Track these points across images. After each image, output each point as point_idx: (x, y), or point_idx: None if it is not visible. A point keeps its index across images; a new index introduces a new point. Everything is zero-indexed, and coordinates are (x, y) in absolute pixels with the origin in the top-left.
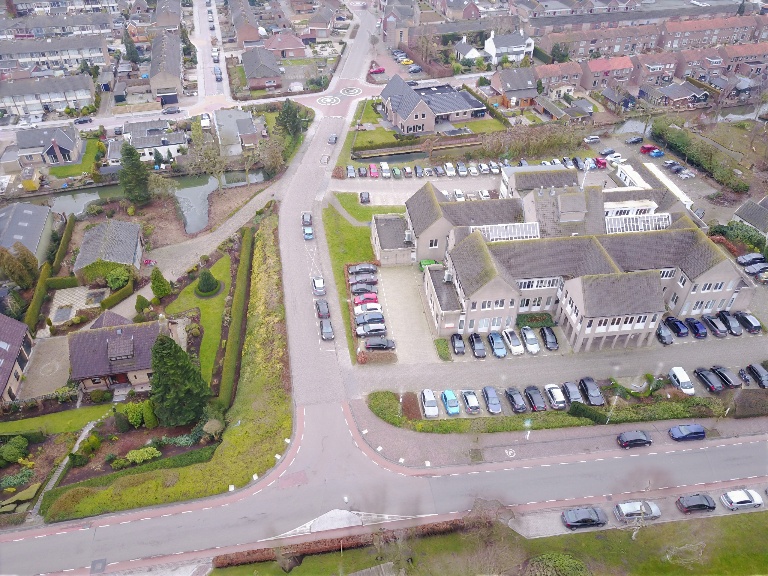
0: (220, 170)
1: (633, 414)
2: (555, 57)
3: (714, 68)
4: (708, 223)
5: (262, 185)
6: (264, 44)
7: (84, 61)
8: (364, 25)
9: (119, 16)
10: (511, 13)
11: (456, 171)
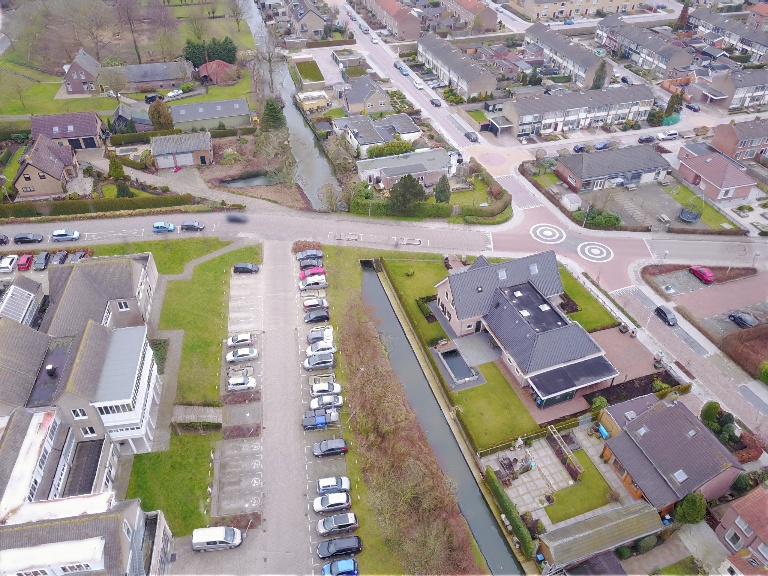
0: None
1: None
2: None
3: None
4: None
5: (299, 205)
6: None
7: (534, 68)
8: None
9: None
10: None
11: None
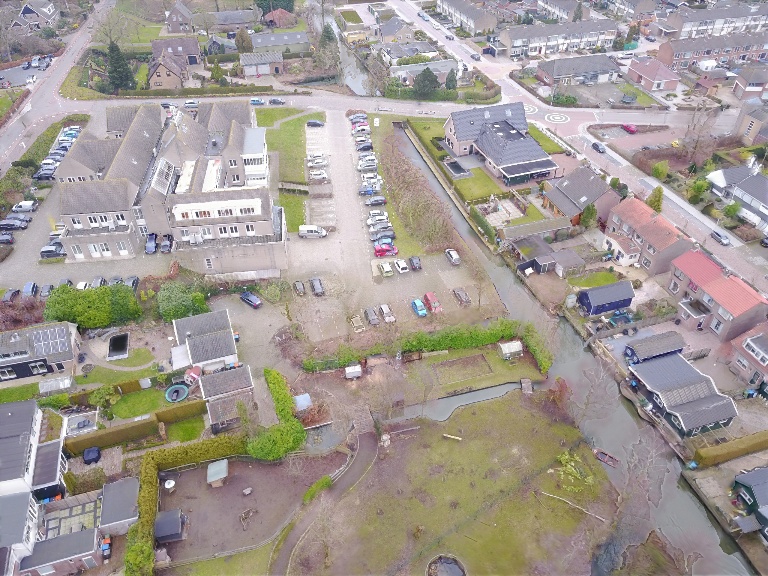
0: None
1: (8, 174)
2: None
3: None
4: None
5: None
6: None
7: (527, 11)
8: None
9: None
10: None
11: None
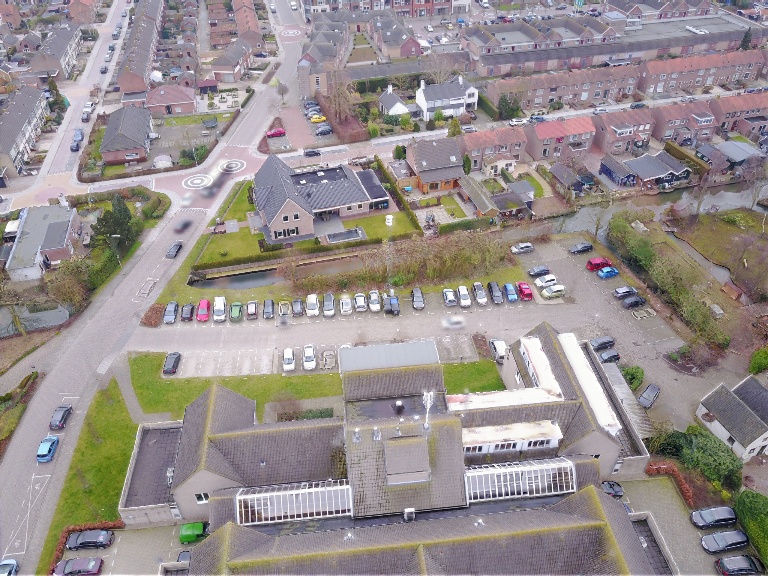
0: (8, 302)
1: None
2: (502, 111)
3: (703, 128)
4: (657, 426)
5: (46, 334)
6: (146, 97)
7: None
8: (287, 63)
9: (3, 55)
10: (461, 48)
11: (322, 306)
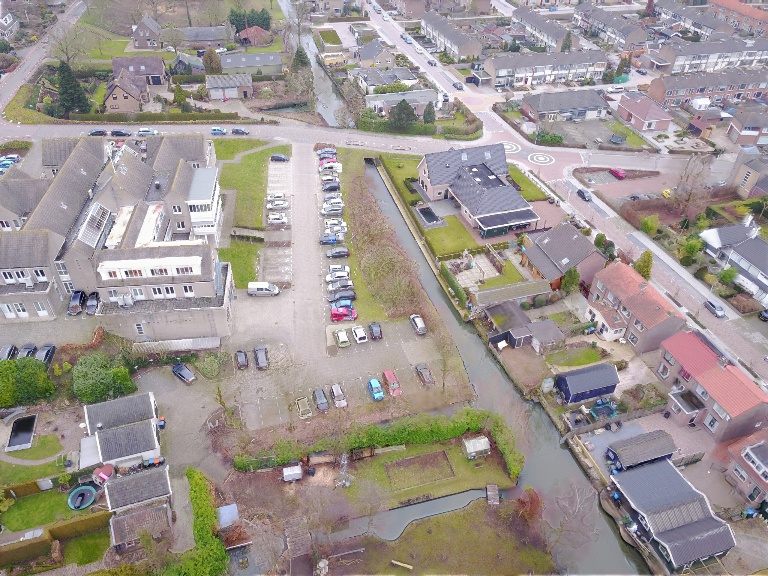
0: None
1: None
2: None
3: None
4: None
5: None
6: None
7: (514, 38)
8: None
9: None
10: None
11: None
